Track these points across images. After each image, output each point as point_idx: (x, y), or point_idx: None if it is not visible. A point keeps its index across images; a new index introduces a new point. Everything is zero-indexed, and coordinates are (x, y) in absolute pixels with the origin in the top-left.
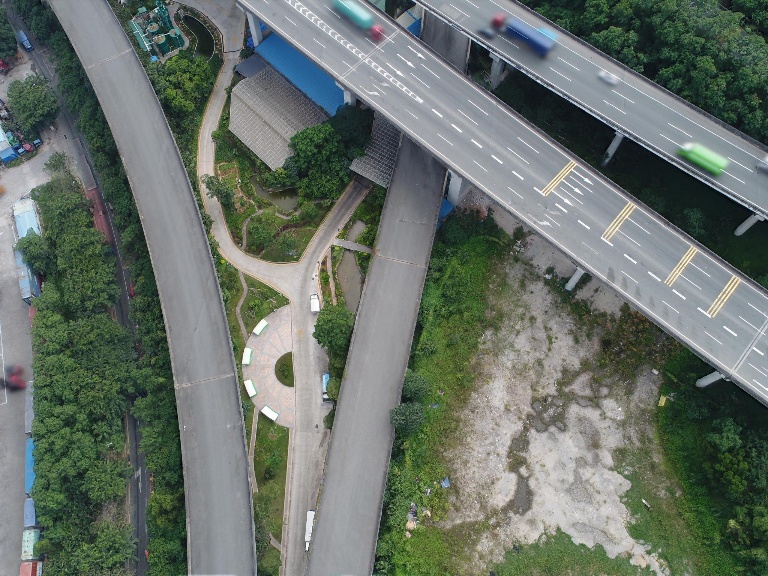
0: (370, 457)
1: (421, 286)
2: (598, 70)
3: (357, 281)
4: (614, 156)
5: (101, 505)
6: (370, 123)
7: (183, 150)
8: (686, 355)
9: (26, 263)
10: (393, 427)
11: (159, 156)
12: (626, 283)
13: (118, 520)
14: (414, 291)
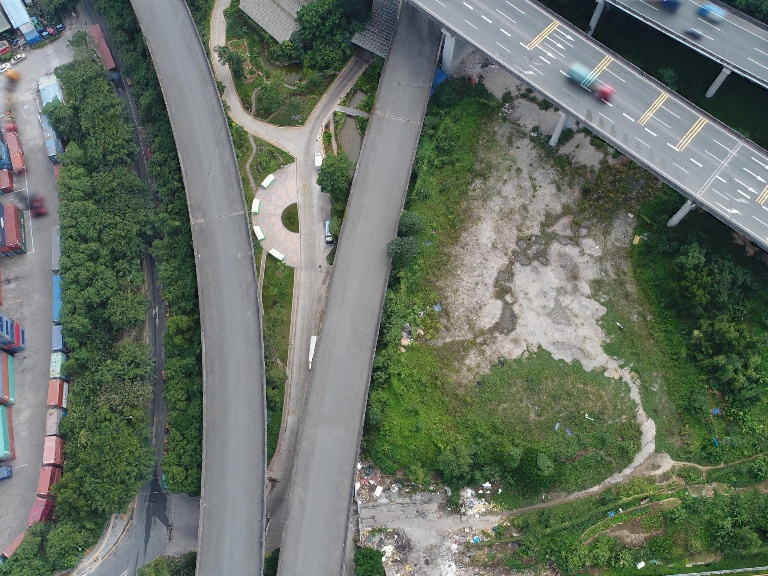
0: (369, 284)
1: (416, 140)
2: None
3: (357, 144)
4: (596, 29)
5: (122, 330)
6: (370, 2)
7: (197, 24)
8: (659, 200)
9: (52, 126)
10: (390, 258)
11: (175, 25)
12: (603, 122)
13: None
14: (410, 144)
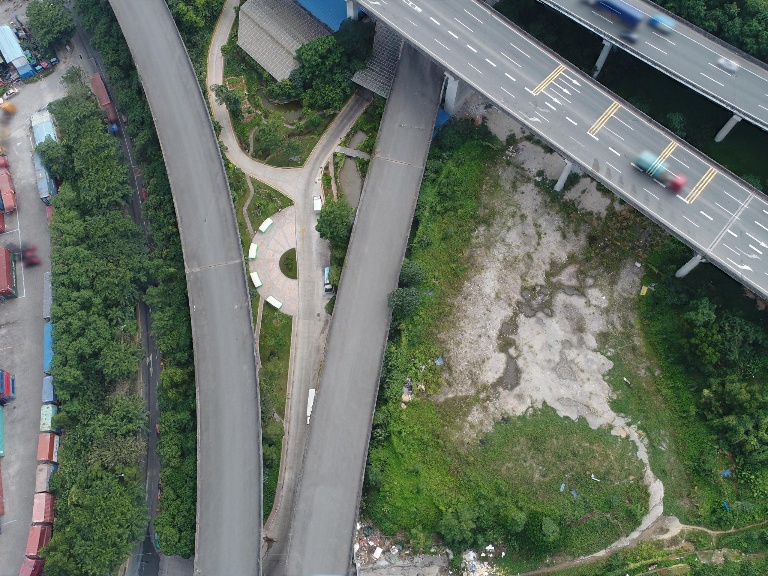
0: (369, 337)
1: (418, 185)
2: None
3: (358, 186)
4: (602, 69)
5: (115, 382)
6: (371, 39)
7: (194, 62)
8: (667, 249)
9: (44, 166)
10: (390, 310)
11: (171, 64)
12: (610, 173)
13: None
14: (411, 189)
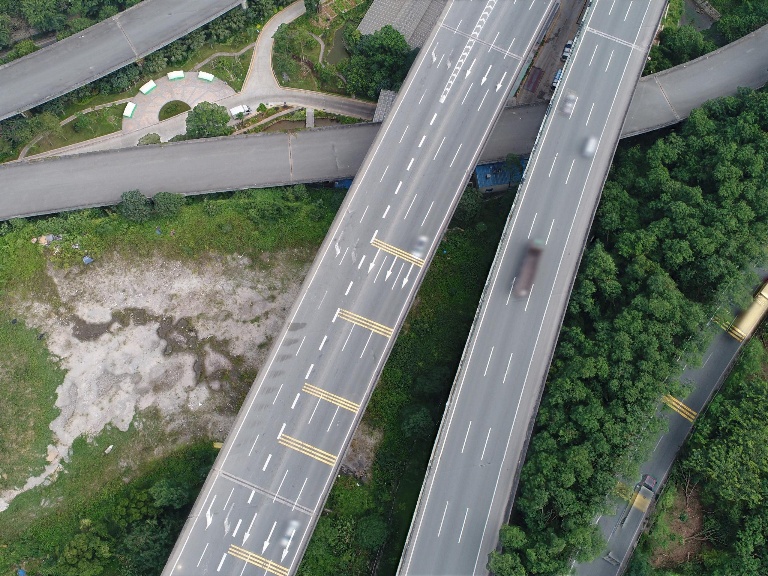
0: (95, 189)
1: (271, 183)
2: (555, 264)
3: None
4: None
5: None
6: None
7: None
8: None
9: None
10: None
11: None
12: (293, 343)
13: None
14: (264, 178)
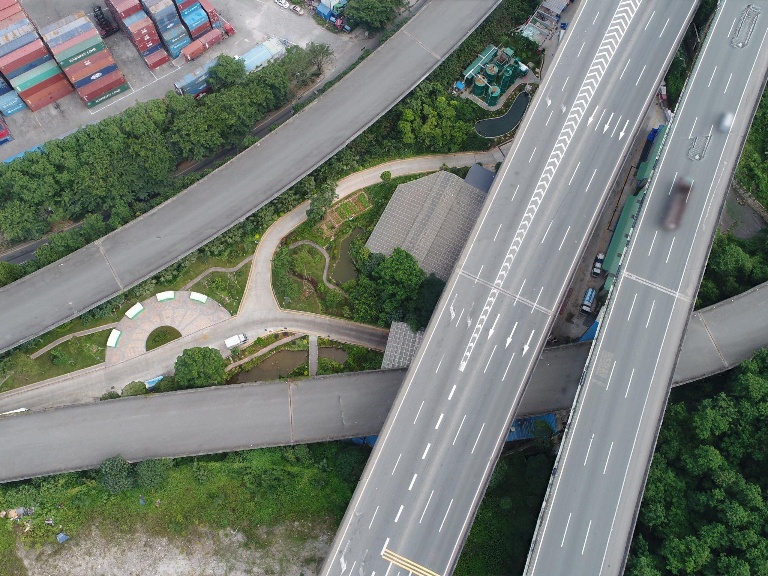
0: (73, 449)
1: (268, 443)
2: None
3: None
4: None
5: None
6: None
7: (356, 152)
8: None
9: (209, 71)
10: None
11: (330, 132)
12: None
13: (3, 245)
14: (261, 438)
